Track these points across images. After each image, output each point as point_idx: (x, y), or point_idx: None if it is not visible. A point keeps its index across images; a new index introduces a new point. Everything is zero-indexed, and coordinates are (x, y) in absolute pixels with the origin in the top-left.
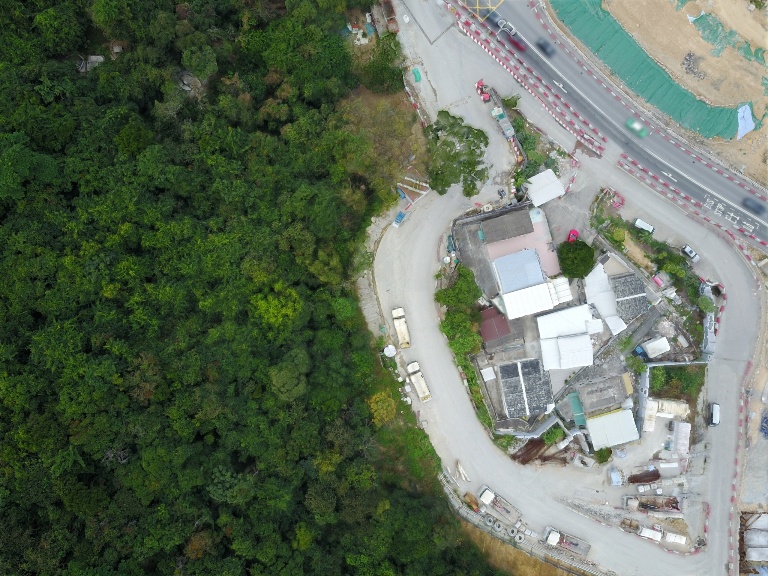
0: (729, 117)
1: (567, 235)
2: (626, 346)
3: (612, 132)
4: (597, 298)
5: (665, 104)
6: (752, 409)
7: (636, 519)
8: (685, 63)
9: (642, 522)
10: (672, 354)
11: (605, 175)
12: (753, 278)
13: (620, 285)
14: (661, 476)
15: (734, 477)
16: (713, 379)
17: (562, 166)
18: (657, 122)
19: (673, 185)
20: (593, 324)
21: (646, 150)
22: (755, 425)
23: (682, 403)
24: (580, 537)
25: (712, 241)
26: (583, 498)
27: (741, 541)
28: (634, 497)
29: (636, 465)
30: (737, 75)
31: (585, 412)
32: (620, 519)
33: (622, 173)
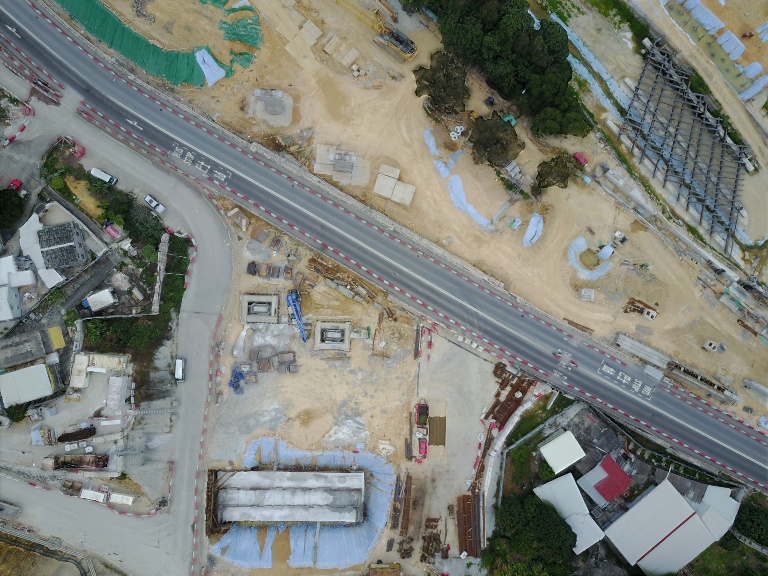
0: (188, 62)
1: (8, 185)
2: (69, 300)
3: (71, 79)
4: (32, 250)
5: (126, 49)
6: (223, 363)
7: (78, 481)
8: (135, 6)
9: (88, 484)
10: (122, 307)
11: (65, 124)
12: (225, 228)
13: (44, 234)
14: (96, 434)
15: (201, 434)
16: (184, 334)
17: (13, 114)
18: (118, 68)
19: (138, 133)
20: (19, 276)
21: (109, 97)
22: (226, 380)
23: (116, 357)
24: (13, 502)
25: (182, 191)
26: (8, 460)
27: (208, 500)
28: (53, 456)
29: (71, 424)
30: (191, 18)
31: (5, 369)
32: (61, 482)
33: (82, 121)
